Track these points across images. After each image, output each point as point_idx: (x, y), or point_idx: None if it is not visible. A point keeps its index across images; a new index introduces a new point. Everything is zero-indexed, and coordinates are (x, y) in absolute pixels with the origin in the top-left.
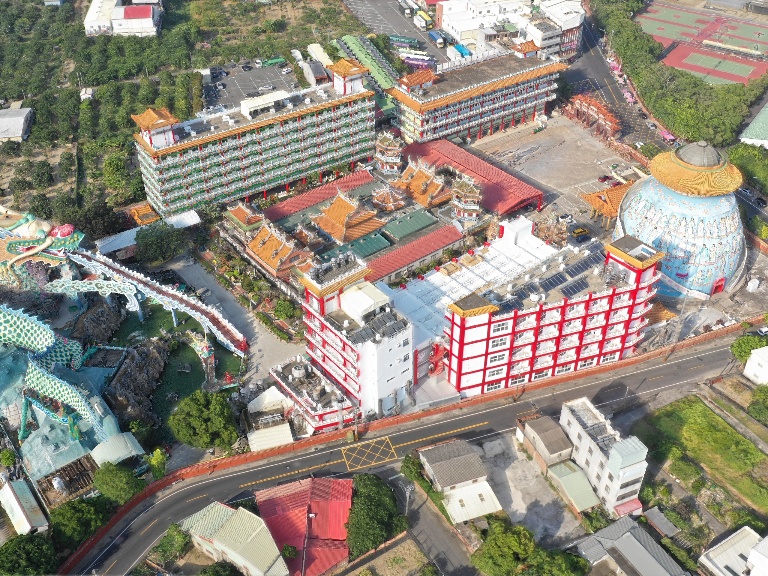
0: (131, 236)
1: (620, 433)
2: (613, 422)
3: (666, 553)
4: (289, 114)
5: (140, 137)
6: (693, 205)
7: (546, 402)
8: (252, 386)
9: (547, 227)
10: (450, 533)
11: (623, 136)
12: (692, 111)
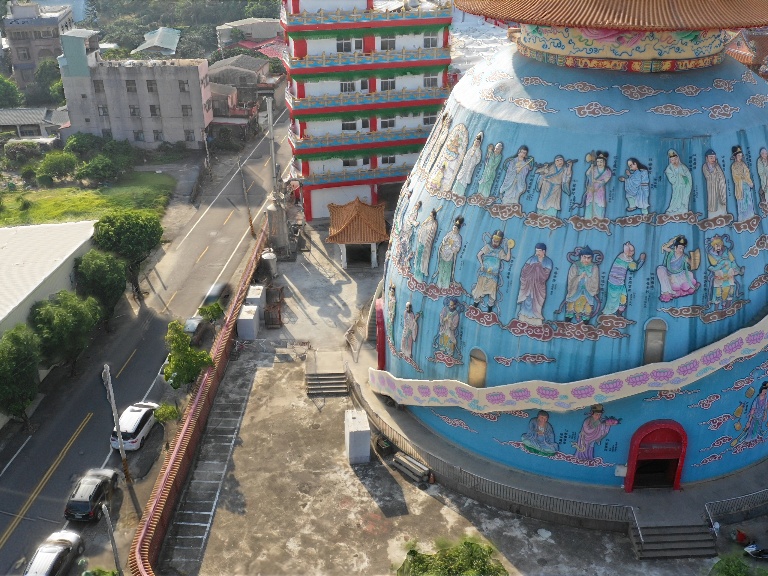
0: None
1: (175, 168)
2: (198, 170)
3: None
4: None
5: None
6: None
7: (286, 149)
8: None
9: None
10: None
11: None
12: None
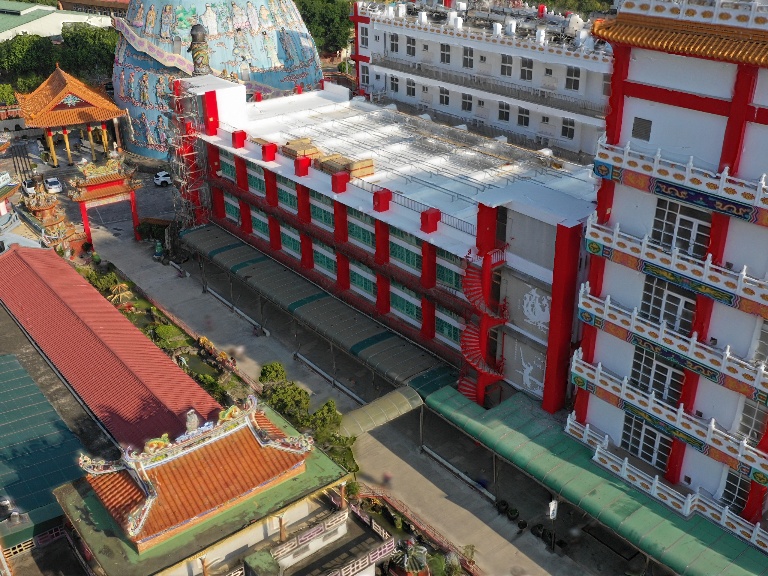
0: None
1: None
2: None
3: None
4: None
5: None
6: None
7: None
8: None
9: None
10: None
11: None
12: None
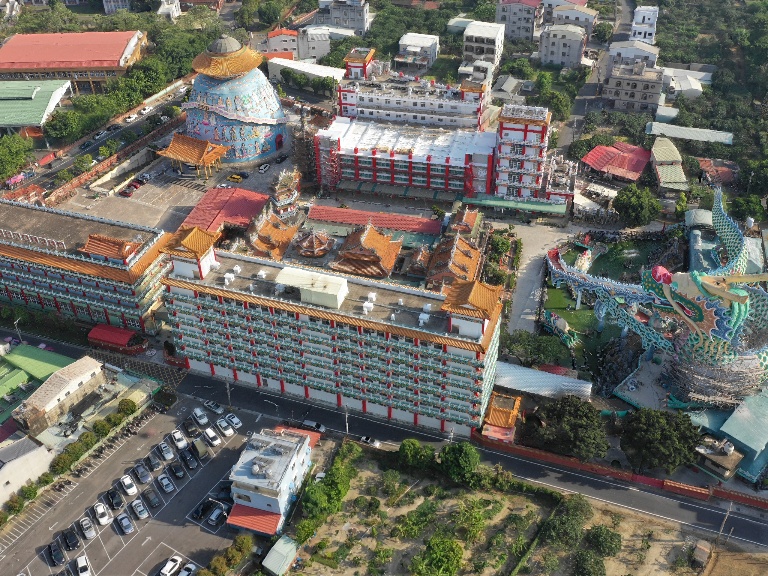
0: (550, 376)
1: None
2: None
3: None
4: None
5: (485, 341)
6: (256, 69)
7: None
8: (588, 207)
9: None
10: (559, 136)
11: None
12: (1, 146)
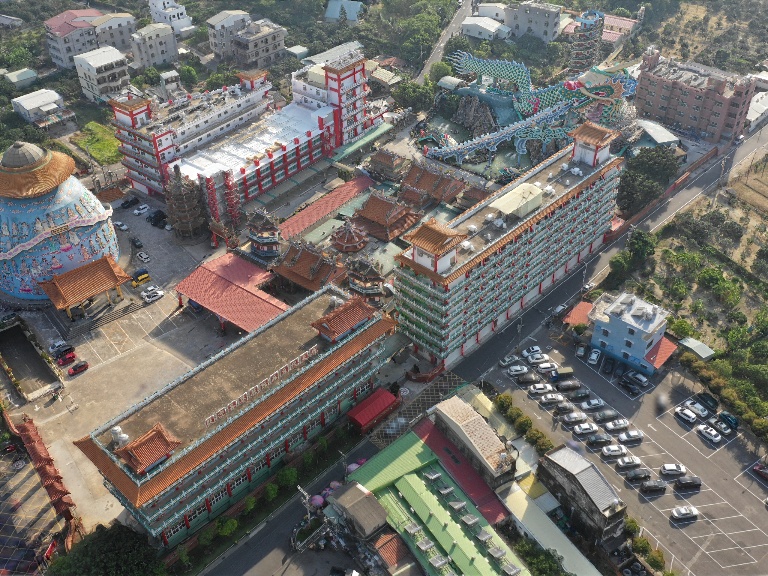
0: None
1: None
2: None
3: (160, 95)
4: (482, 204)
5: None
6: None
7: None
8: None
9: (186, 182)
10: None
11: (3, 481)
12: None
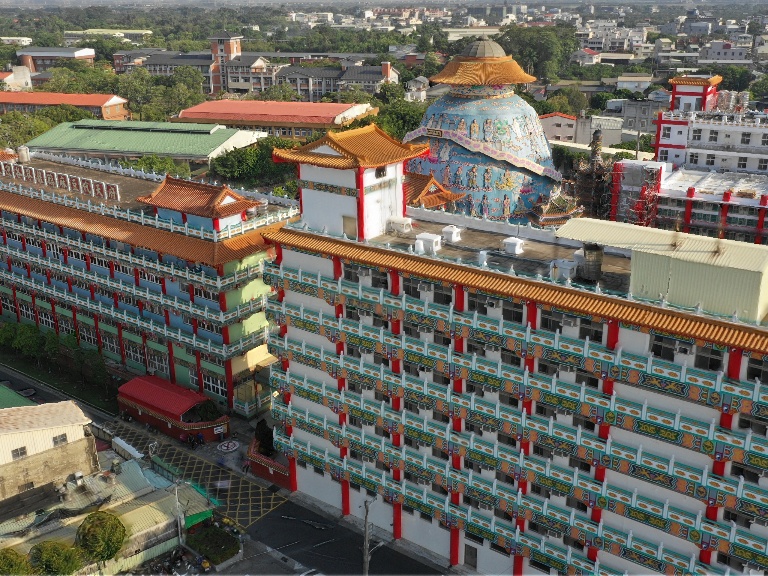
0: None
1: None
2: None
3: None
4: None
5: None
6: None
7: None
8: None
9: None
10: None
11: None
12: None
